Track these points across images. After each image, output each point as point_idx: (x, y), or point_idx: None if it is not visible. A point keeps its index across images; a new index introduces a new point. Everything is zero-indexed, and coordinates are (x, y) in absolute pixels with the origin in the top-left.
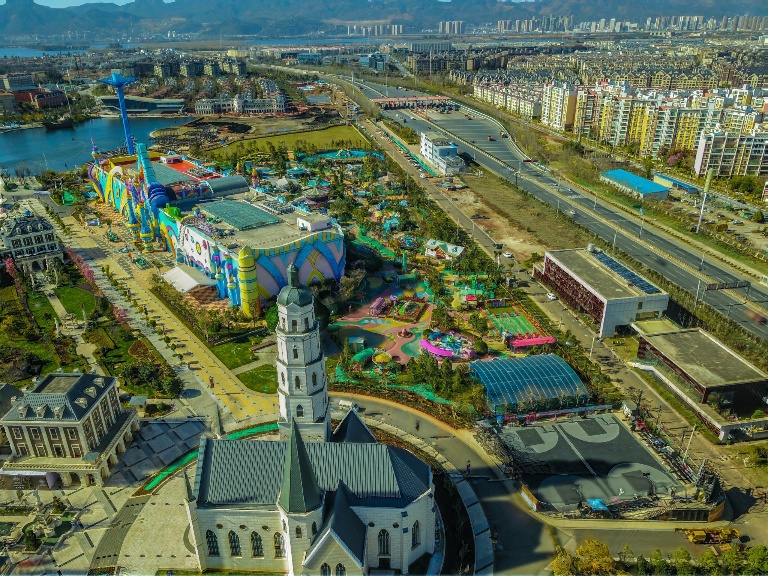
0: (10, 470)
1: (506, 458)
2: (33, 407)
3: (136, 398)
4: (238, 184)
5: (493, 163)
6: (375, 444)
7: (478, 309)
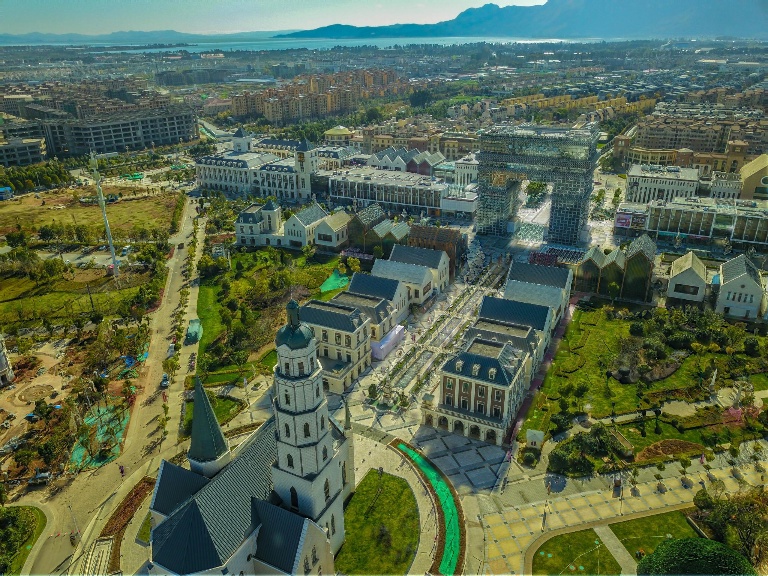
0: None
1: None
2: None
3: (537, 433)
4: None
5: None
6: (203, 491)
7: None
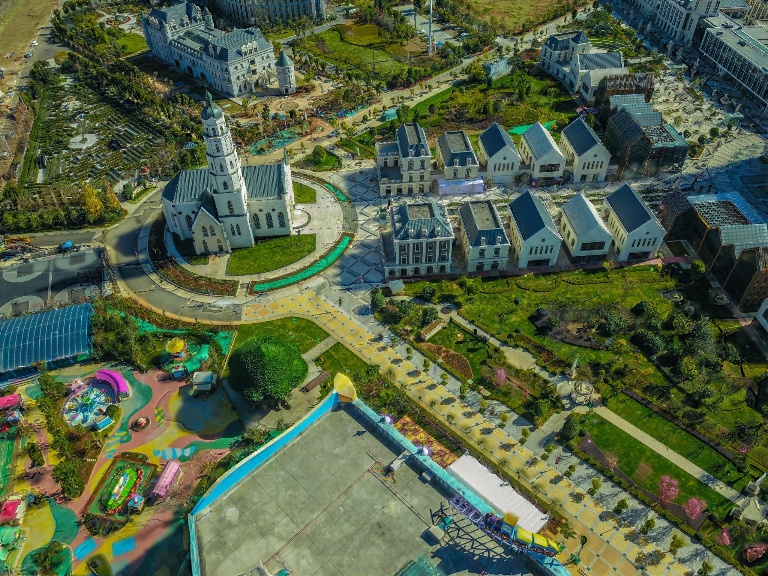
0: None
1: None
2: None
3: (399, 284)
4: None
5: None
6: None
7: None
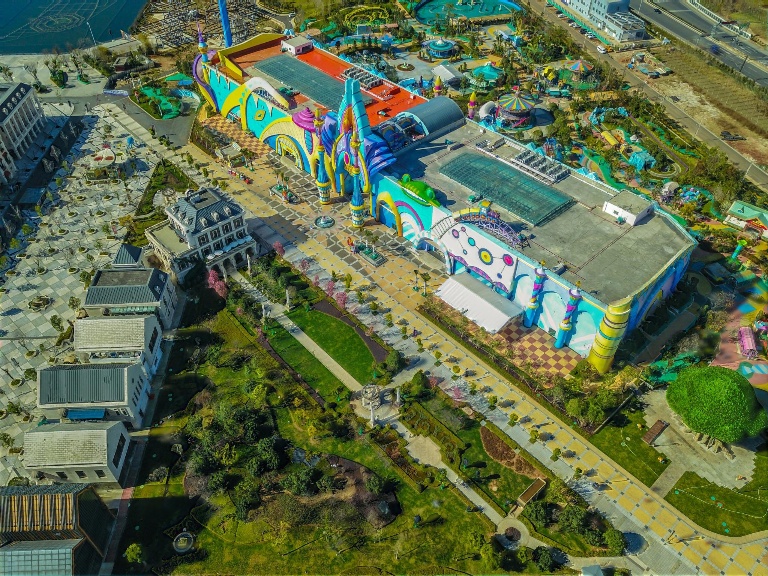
0: None
1: None
2: None
3: (591, 574)
4: (453, 115)
5: (663, 17)
6: None
7: None
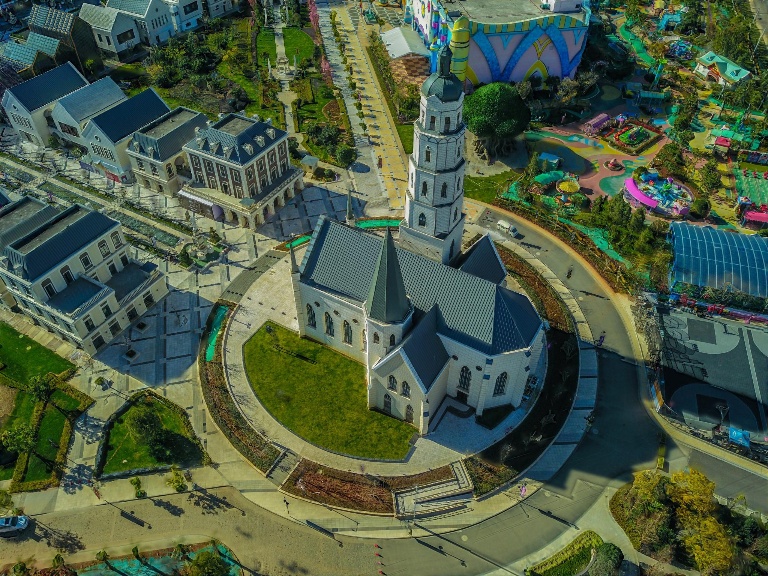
0: (188, 193)
1: (652, 344)
2: (209, 141)
3: (308, 158)
4: None
5: None
6: (485, 281)
7: (726, 158)
